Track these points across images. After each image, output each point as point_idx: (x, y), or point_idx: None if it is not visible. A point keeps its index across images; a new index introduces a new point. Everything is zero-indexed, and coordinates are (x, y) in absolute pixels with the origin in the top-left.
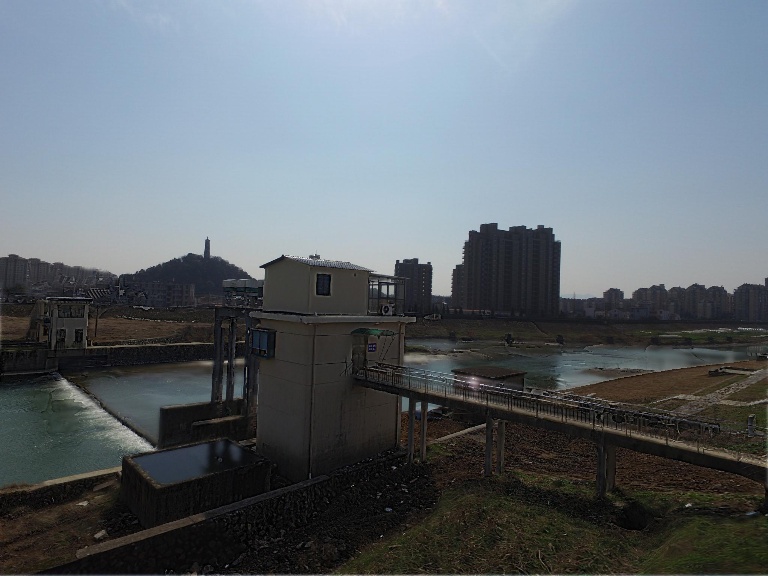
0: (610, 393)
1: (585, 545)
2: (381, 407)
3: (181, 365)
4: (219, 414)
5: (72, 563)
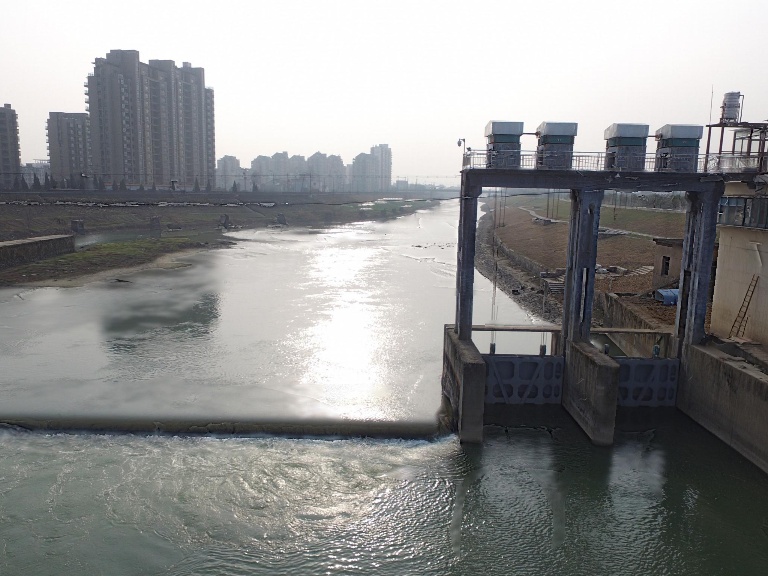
0: (602, 261)
1: None
2: None
3: None
4: None
5: None
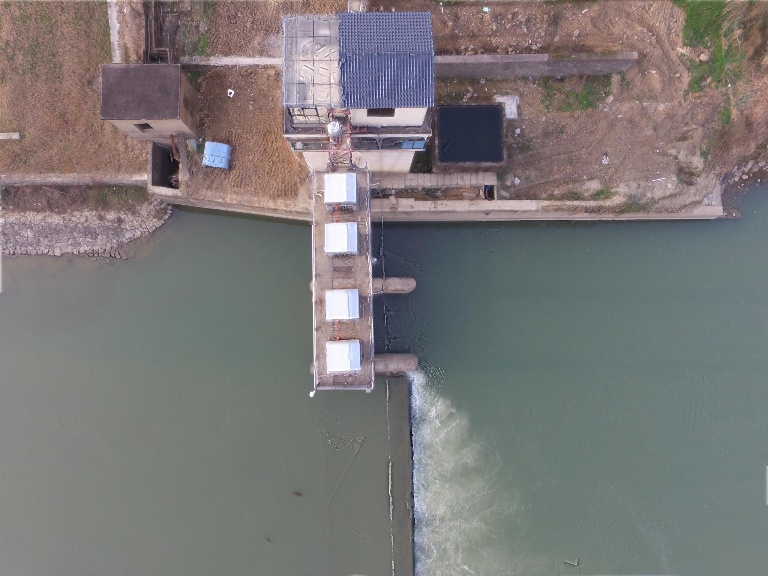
0: None
1: None
2: None
3: None
4: None
5: None
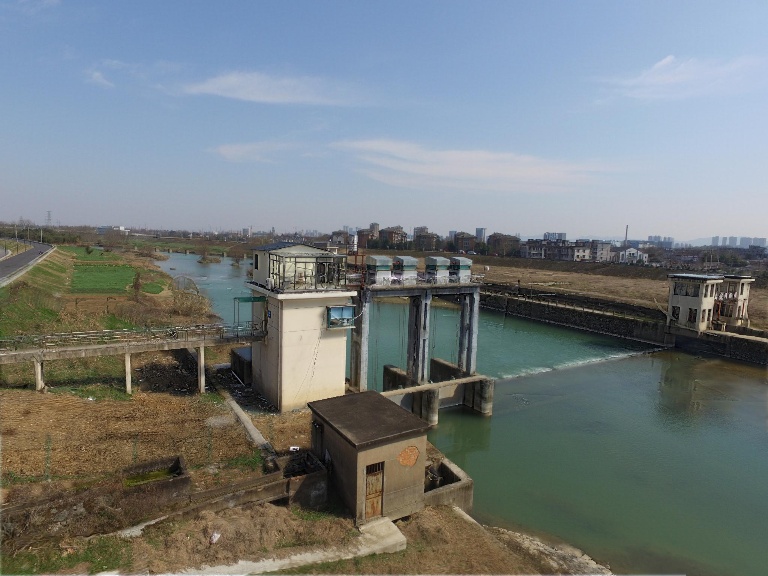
0: None
1: (34, 377)
2: (273, 367)
3: None
4: None
5: None
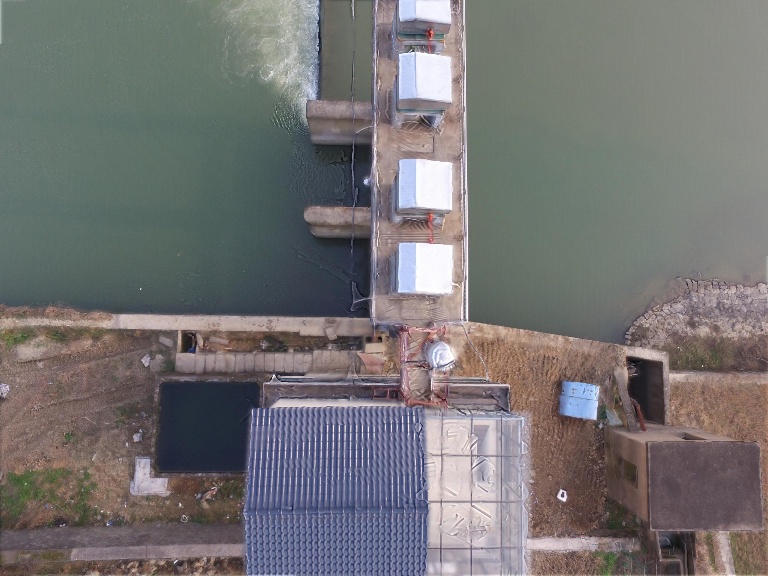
0: None
1: None
2: None
3: None
4: None
5: (68, 561)
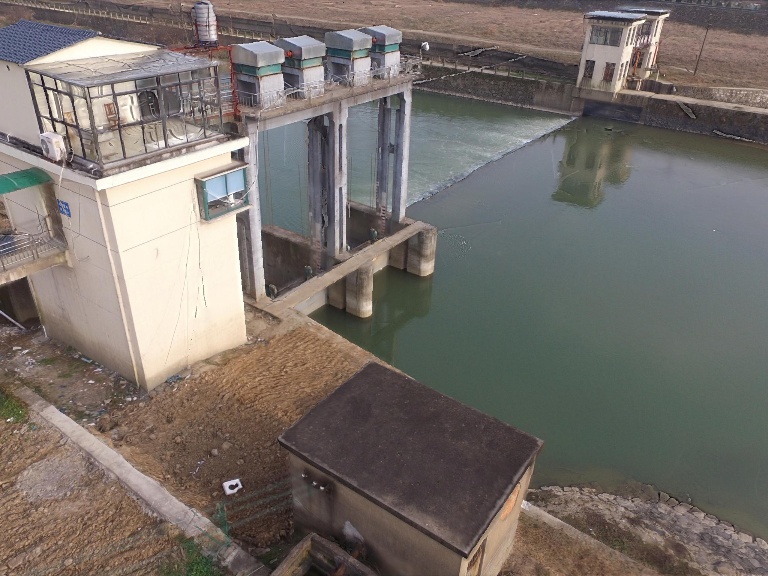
0: None
1: None
2: (104, 311)
3: (739, 150)
4: (382, 233)
5: None
